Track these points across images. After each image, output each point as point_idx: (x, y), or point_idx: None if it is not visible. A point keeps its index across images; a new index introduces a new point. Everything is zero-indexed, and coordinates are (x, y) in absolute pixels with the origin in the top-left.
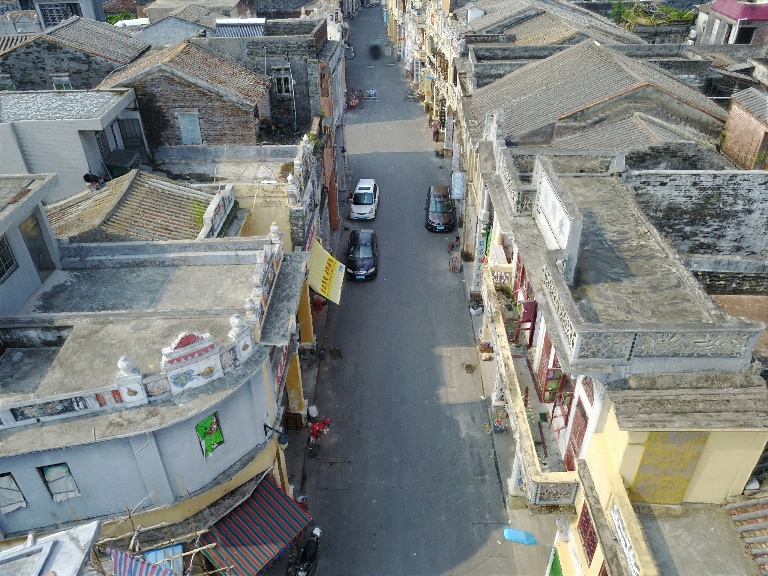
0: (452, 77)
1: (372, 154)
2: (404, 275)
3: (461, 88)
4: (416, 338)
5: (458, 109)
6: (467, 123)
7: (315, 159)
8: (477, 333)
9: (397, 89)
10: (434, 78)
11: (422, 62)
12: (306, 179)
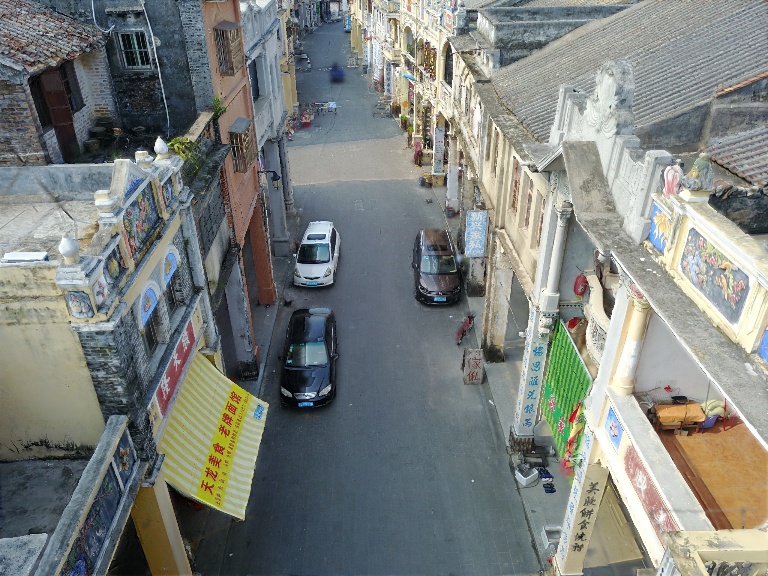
0: (442, 72)
1: (331, 184)
2: (385, 394)
3: (470, 70)
4: (416, 553)
5: (456, 114)
6: (497, 120)
7: (188, 193)
8: (538, 535)
9: (364, 103)
10: (413, 81)
11: (395, 66)
12: (149, 241)
